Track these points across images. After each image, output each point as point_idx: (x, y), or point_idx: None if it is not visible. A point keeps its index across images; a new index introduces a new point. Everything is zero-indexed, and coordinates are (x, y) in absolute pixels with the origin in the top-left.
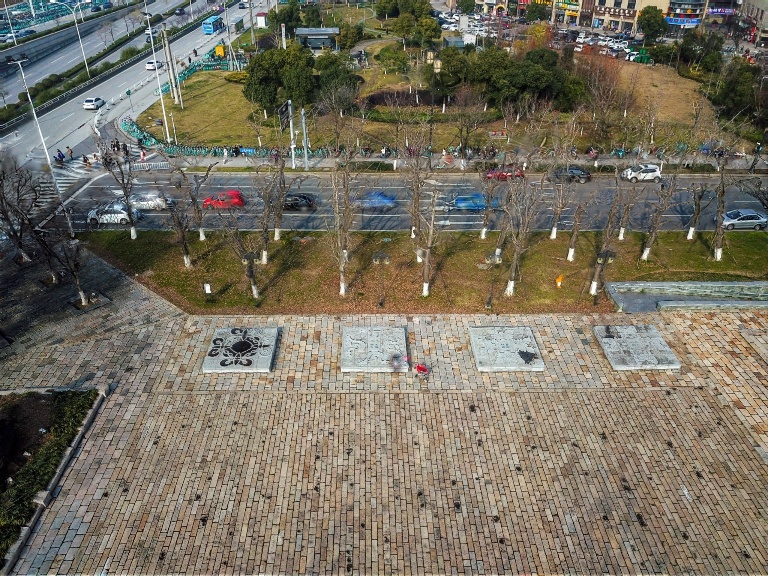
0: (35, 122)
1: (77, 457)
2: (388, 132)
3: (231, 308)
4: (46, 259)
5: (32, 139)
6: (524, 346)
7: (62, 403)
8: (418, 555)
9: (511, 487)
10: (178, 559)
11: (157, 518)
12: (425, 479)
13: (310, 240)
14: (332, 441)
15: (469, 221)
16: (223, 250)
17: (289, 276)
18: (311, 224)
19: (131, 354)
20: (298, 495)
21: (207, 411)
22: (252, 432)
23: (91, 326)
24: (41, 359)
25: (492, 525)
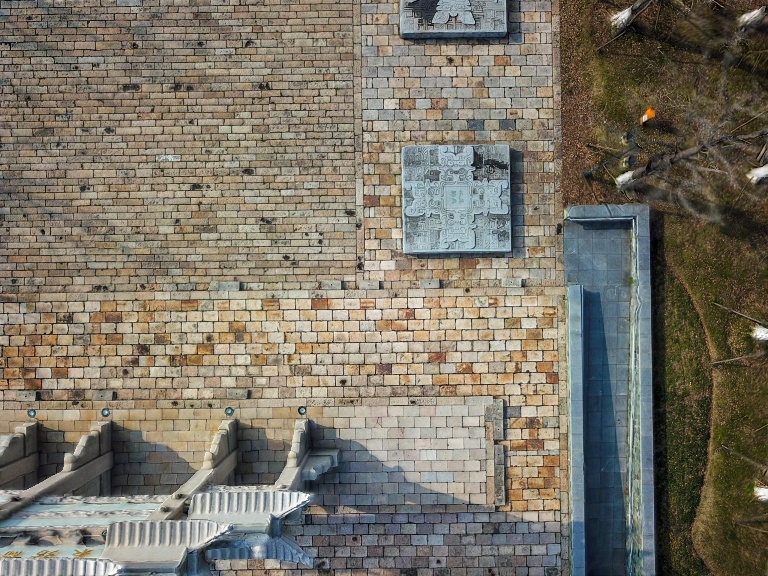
0: None
1: None
2: None
3: None
4: None
5: None
6: (450, 9)
7: None
8: None
9: None
10: None
11: None
12: None
13: None
14: None
15: None
16: None
17: None
18: None
19: None
20: None
21: None
22: None
23: None
24: None
25: None
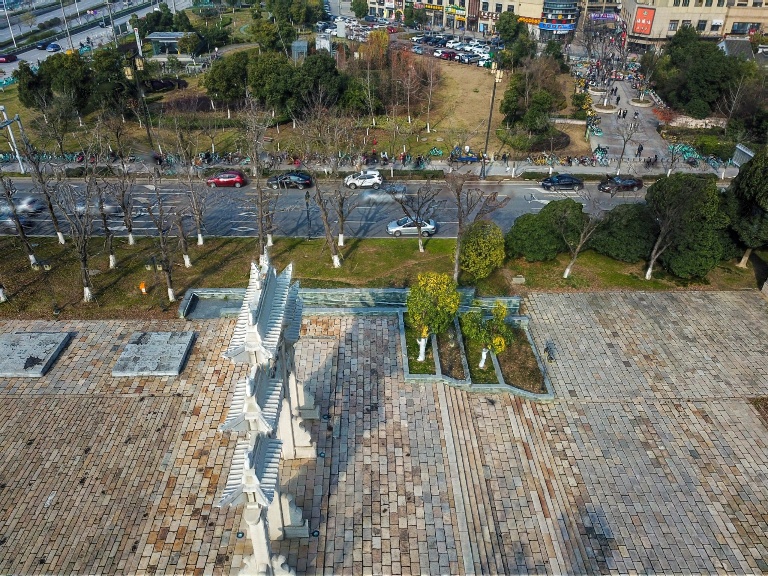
0: None
1: None
2: None
3: None
4: None
5: None
6: (40, 352)
7: None
8: None
9: None
10: None
11: None
12: None
13: None
14: None
15: (145, 227)
16: None
17: None
18: None
19: None
20: None
21: None
22: None
23: None
24: None
25: None
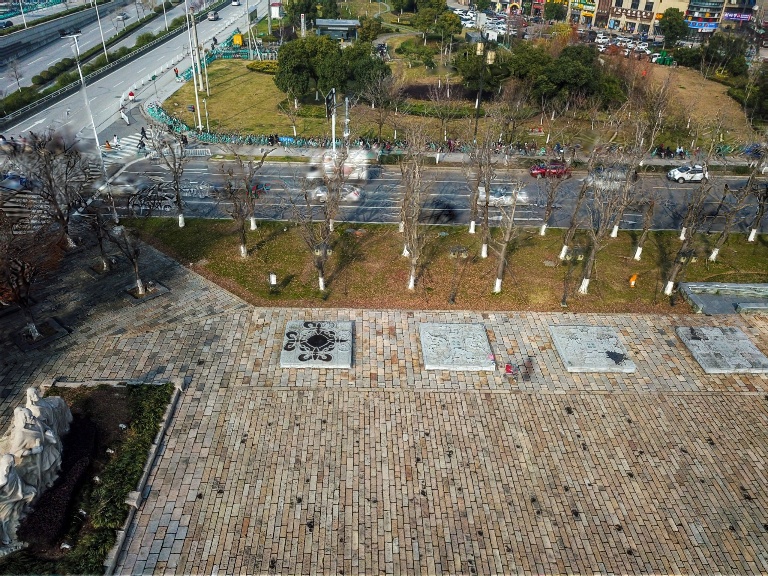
0: (87, 100)
1: (162, 455)
2: (434, 124)
3: (297, 300)
4: (93, 245)
5: (82, 118)
6: (611, 346)
7: (138, 397)
8: (545, 566)
9: (627, 494)
10: (290, 567)
11: (259, 522)
12: (535, 484)
13: (365, 232)
14: (430, 442)
15: (523, 217)
16: (278, 240)
17: (352, 269)
18: (362, 216)
19: (200, 346)
20: (405, 500)
21: (292, 408)
22: (344, 431)
23: (153, 316)
24: (105, 350)
25: (616, 534)
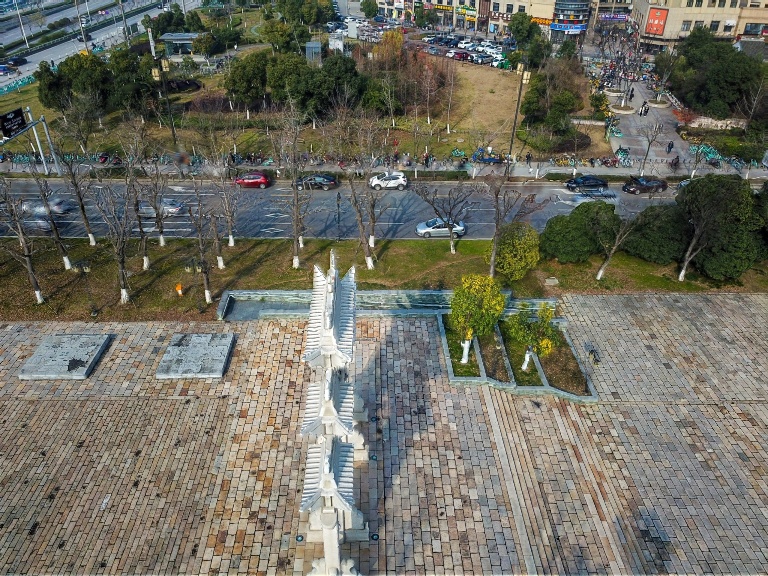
0: None
1: None
2: None
3: None
4: None
5: None
6: (82, 354)
7: None
8: None
9: None
10: None
11: None
12: None
13: None
14: None
15: (173, 228)
16: None
17: None
18: None
19: None
20: None
21: None
22: None
23: None
24: None
25: None
